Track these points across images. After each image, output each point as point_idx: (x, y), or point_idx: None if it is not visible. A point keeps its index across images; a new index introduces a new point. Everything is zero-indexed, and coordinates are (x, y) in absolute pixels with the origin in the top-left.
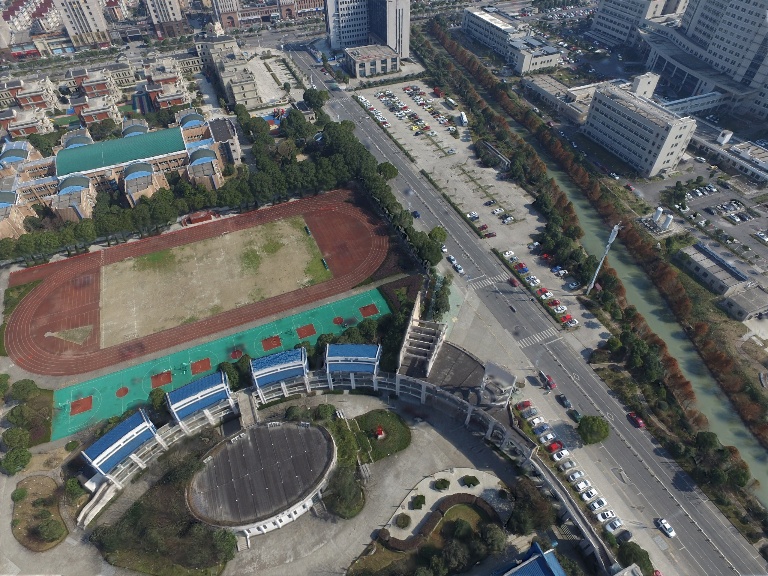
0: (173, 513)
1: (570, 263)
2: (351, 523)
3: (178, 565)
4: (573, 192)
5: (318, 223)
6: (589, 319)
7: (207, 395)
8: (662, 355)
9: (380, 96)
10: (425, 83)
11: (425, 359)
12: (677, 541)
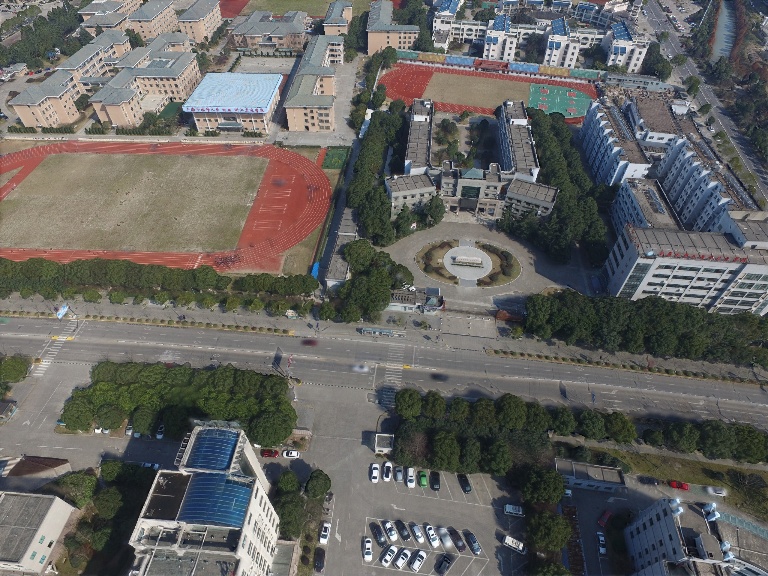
0: None
1: None
2: None
3: None
4: (730, 16)
5: None
6: (691, 33)
7: (537, 0)
8: None
9: None
10: None
11: (614, 7)
12: (670, 58)
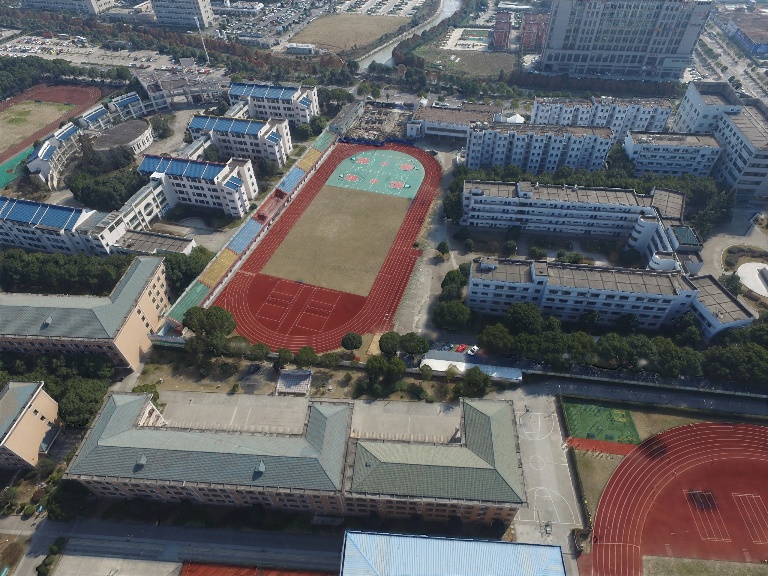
0: (95, 160)
1: (194, 60)
2: (173, 136)
3: (115, 171)
4: None
5: (41, 98)
6: (216, 69)
7: (67, 130)
8: (247, 61)
9: (4, 49)
10: (31, 36)
11: (157, 83)
12: None
